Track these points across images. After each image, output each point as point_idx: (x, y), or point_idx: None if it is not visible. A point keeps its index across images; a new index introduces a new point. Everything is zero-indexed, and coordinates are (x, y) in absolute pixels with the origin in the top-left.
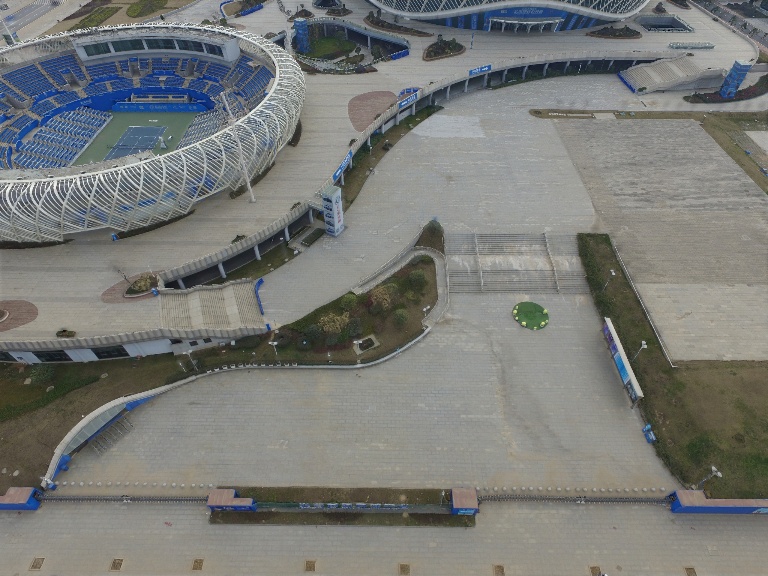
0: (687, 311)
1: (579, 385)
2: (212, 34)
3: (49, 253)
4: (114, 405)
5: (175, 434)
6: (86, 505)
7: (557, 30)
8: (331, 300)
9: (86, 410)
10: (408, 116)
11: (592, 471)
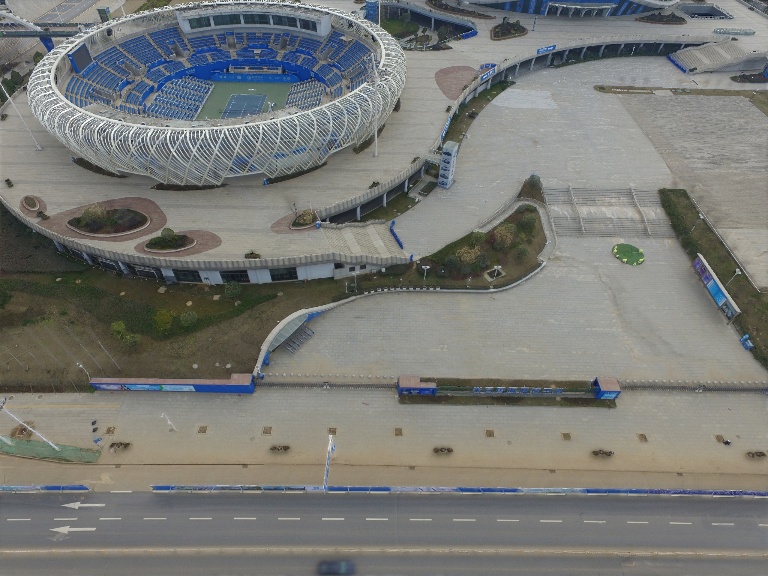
0: (765, 250)
1: (680, 307)
2: (306, 10)
3: (211, 194)
4: (300, 314)
5: (350, 340)
6: (293, 390)
7: (608, 15)
8: (458, 238)
9: (279, 317)
10: (484, 90)
11: (704, 369)
